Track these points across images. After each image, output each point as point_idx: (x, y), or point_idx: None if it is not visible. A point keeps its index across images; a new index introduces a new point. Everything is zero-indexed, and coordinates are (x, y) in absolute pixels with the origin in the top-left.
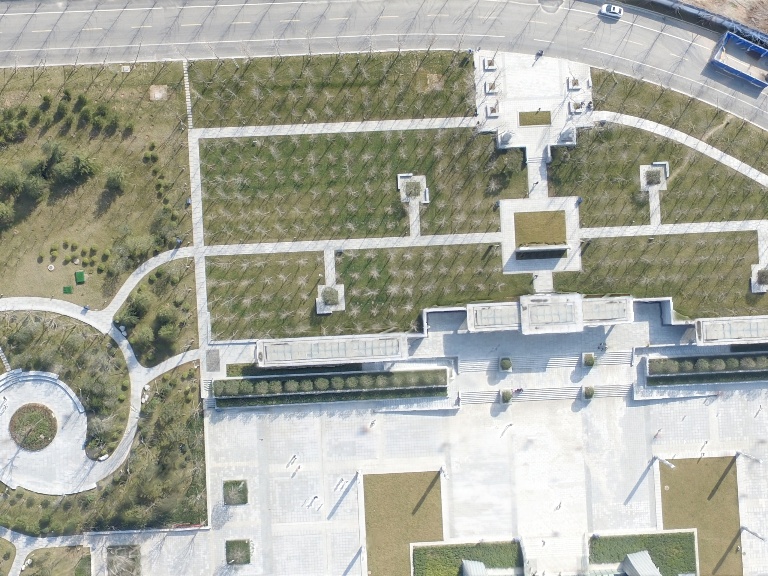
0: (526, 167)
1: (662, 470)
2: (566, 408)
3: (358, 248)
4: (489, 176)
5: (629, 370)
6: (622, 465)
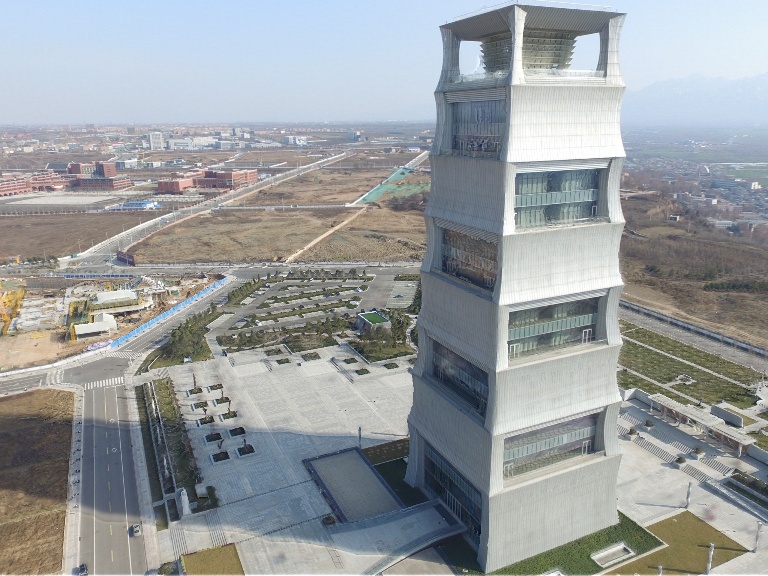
0: (755, 405)
1: (683, 514)
2: (659, 461)
3: (635, 374)
4: (730, 396)
5: (720, 475)
6: (659, 494)
